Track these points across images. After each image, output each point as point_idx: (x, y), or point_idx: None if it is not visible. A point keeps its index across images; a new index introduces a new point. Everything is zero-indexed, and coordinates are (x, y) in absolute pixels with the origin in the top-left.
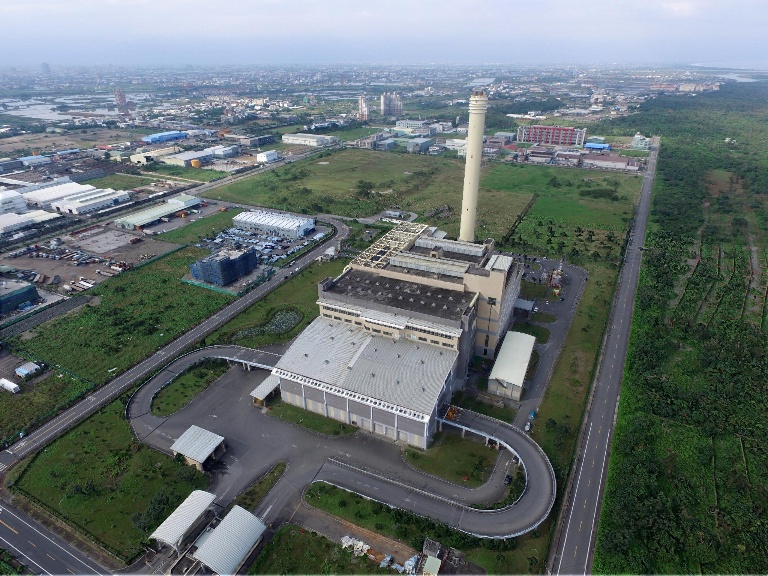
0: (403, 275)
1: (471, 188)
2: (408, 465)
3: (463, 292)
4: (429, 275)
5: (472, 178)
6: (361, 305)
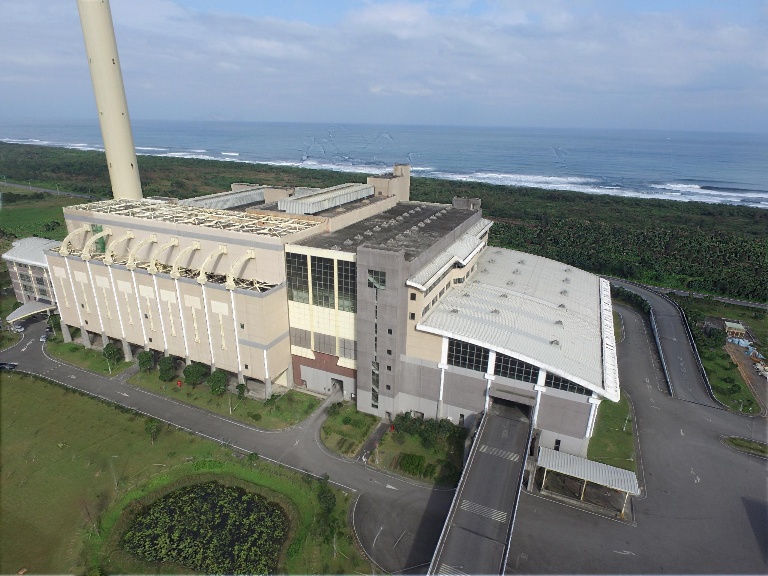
0: (354, 213)
1: (127, 123)
2: (622, 341)
3: (397, 206)
4: (357, 205)
5: (123, 104)
6: (440, 250)
